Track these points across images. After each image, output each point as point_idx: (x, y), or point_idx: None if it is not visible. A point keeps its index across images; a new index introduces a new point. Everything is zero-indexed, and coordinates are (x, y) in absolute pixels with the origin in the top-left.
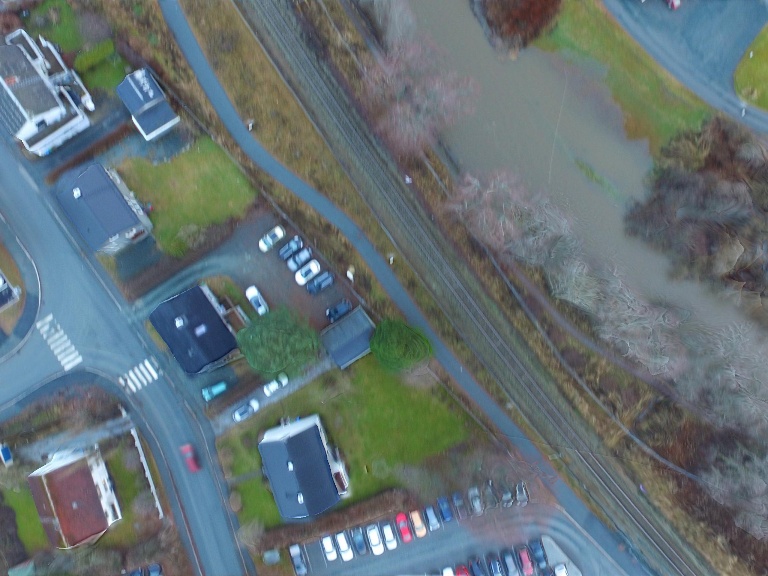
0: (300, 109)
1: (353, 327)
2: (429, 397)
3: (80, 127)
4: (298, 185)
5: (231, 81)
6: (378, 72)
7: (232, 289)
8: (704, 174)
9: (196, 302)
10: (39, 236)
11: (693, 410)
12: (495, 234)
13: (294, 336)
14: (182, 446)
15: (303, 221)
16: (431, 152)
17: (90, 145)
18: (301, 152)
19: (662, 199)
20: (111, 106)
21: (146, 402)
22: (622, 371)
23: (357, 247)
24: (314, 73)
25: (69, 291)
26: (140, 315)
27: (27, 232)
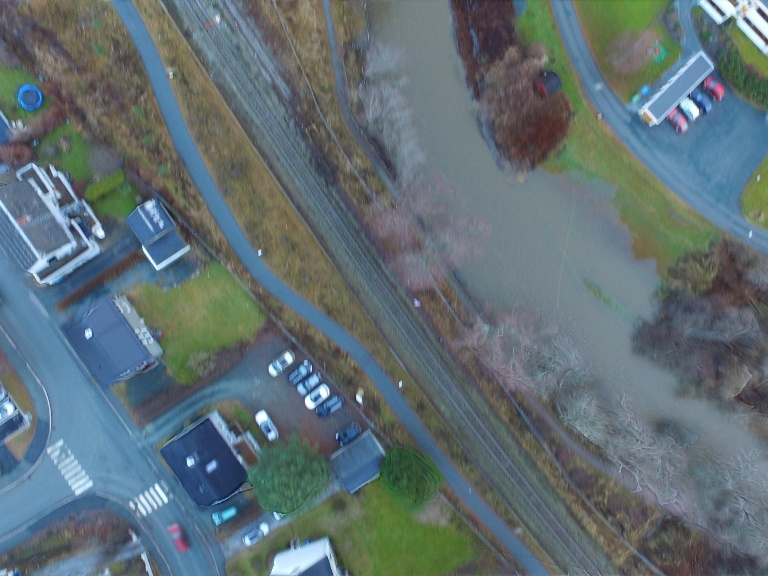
0: (309, 234)
1: (363, 454)
2: (438, 518)
3: (90, 255)
4: (307, 310)
5: (241, 207)
6: (387, 196)
7: (242, 413)
8: (712, 298)
9: (207, 437)
10: (50, 362)
11: (701, 529)
12: (504, 369)
13: (305, 478)
14: (192, 569)
15: (312, 345)
16: (440, 275)
17: (100, 272)
18: (310, 277)
19: (670, 320)
20: (121, 233)
21: (156, 526)
22: (630, 491)
23: (366, 370)
24: (323, 198)
25: (80, 416)
26: (150, 440)
27: (38, 358)
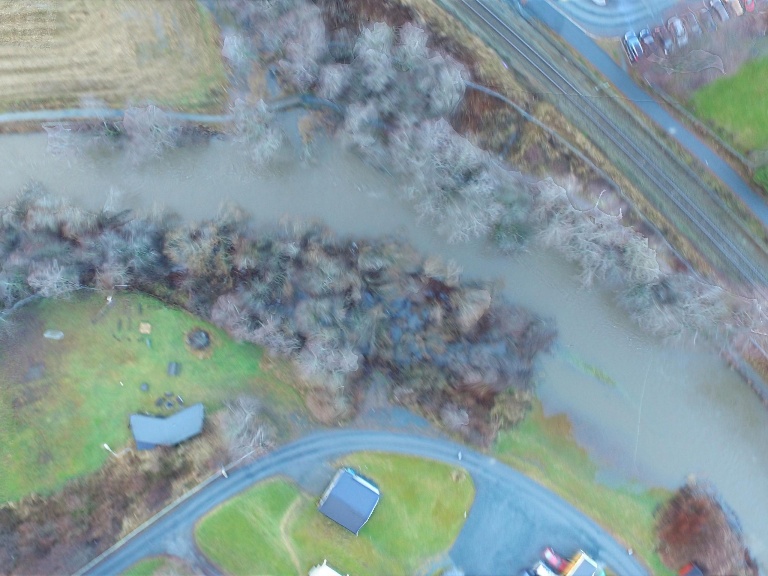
0: None
1: None
2: (735, 131)
3: None
4: None
5: None
6: None
7: None
8: None
9: None
10: None
11: None
12: None
13: None
14: None
15: None
16: (764, 373)
17: None
18: None
19: None
20: None
21: None
22: None
23: None
24: None
25: None
26: None
27: None
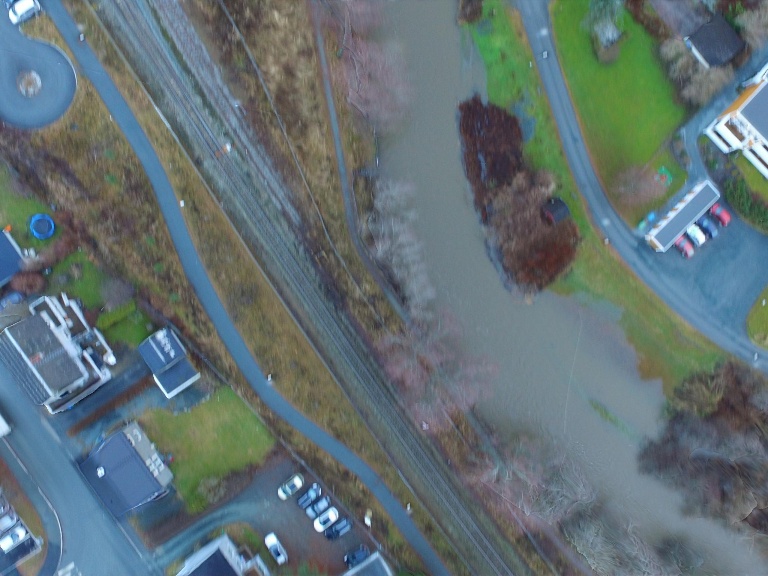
0: (319, 359)
1: None
2: None
3: (102, 382)
4: (316, 433)
5: (251, 333)
6: (395, 321)
7: (251, 536)
8: (717, 422)
9: (217, 570)
10: (61, 486)
11: None
12: None
13: None
14: None
15: (321, 468)
16: (448, 398)
17: (111, 397)
18: (320, 401)
19: (676, 442)
20: (132, 358)
21: None
22: None
23: (375, 493)
24: (332, 323)
25: (90, 540)
26: (160, 562)
27: (49, 482)
